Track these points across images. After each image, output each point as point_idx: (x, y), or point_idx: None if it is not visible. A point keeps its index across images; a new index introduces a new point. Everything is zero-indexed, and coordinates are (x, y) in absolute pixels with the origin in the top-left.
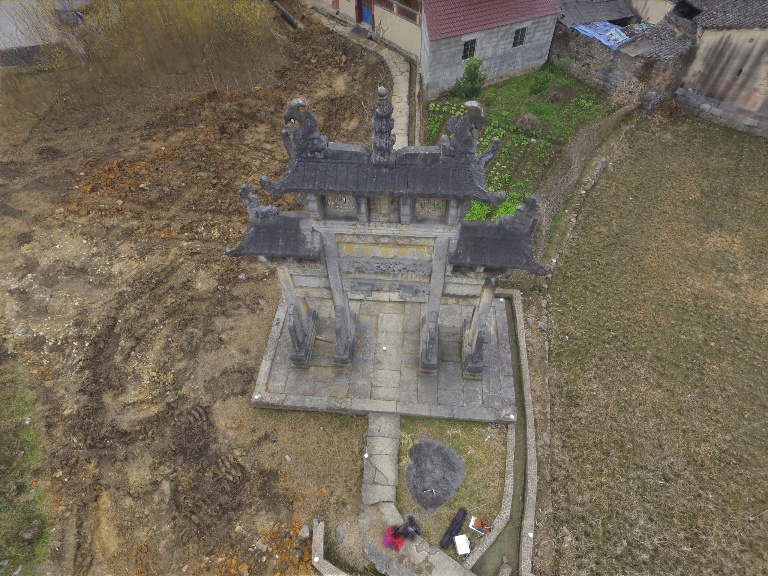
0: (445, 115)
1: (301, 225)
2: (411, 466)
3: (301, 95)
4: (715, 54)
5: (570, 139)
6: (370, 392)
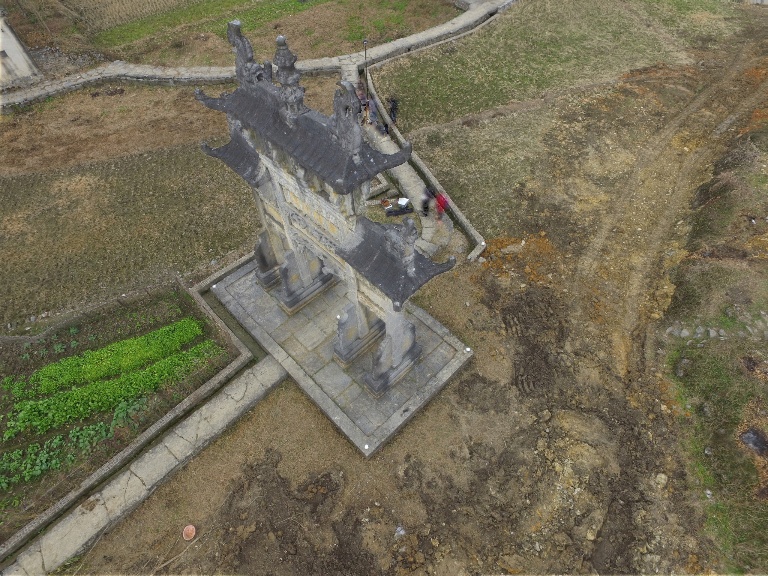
0: None
1: None
2: None
3: None
4: None
5: None
6: None
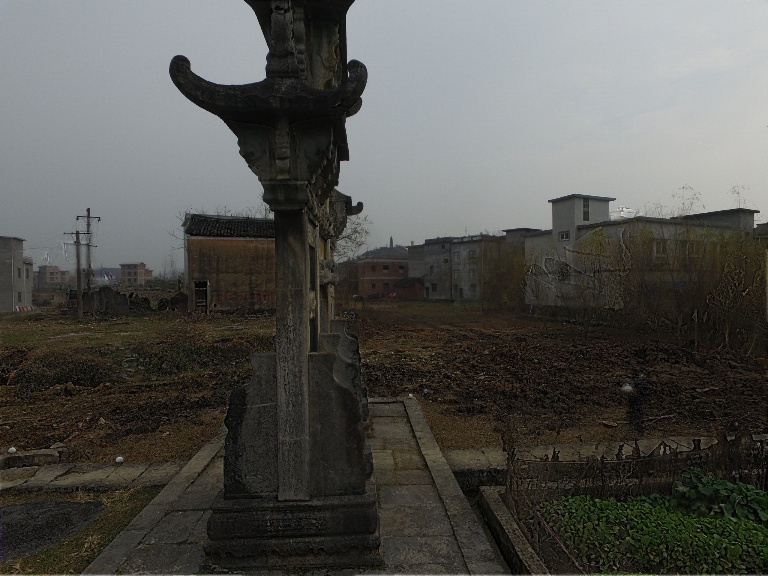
0: None
1: None
2: None
3: None
4: None
5: None
6: None
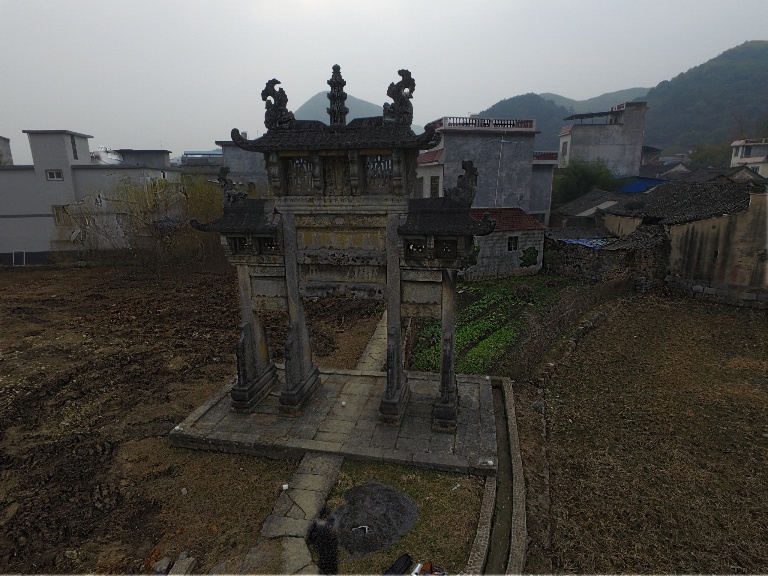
0: None
1: (265, 207)
2: (343, 506)
3: None
4: (687, 243)
5: None
6: (314, 435)
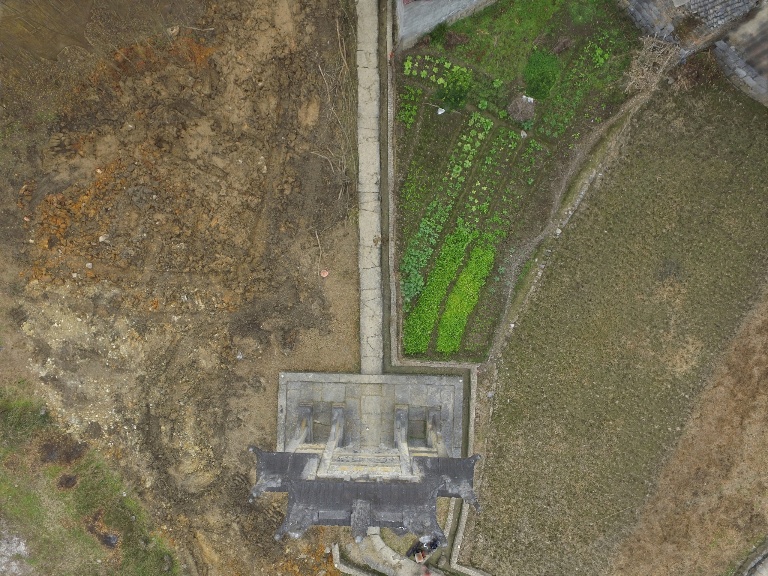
0: (424, 83)
1: None
2: None
3: (238, 52)
4: None
5: (560, 167)
6: None
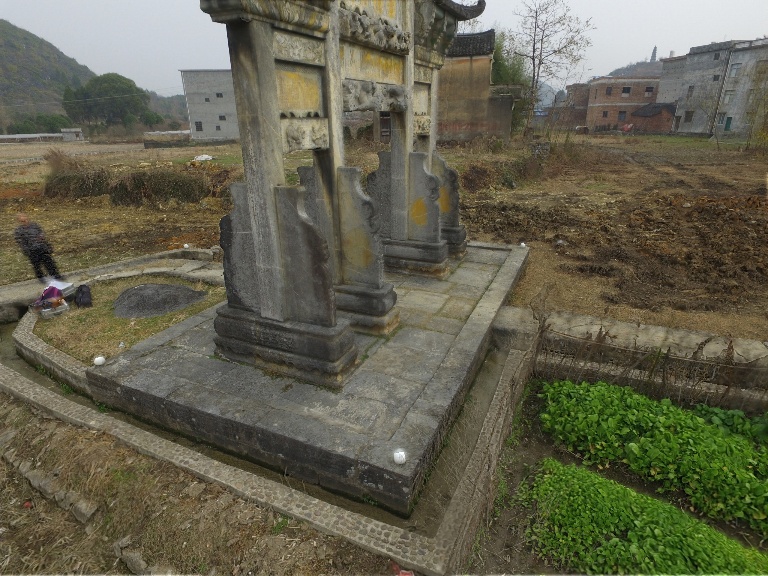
0: None
1: None
2: None
3: None
4: None
5: None
6: None
